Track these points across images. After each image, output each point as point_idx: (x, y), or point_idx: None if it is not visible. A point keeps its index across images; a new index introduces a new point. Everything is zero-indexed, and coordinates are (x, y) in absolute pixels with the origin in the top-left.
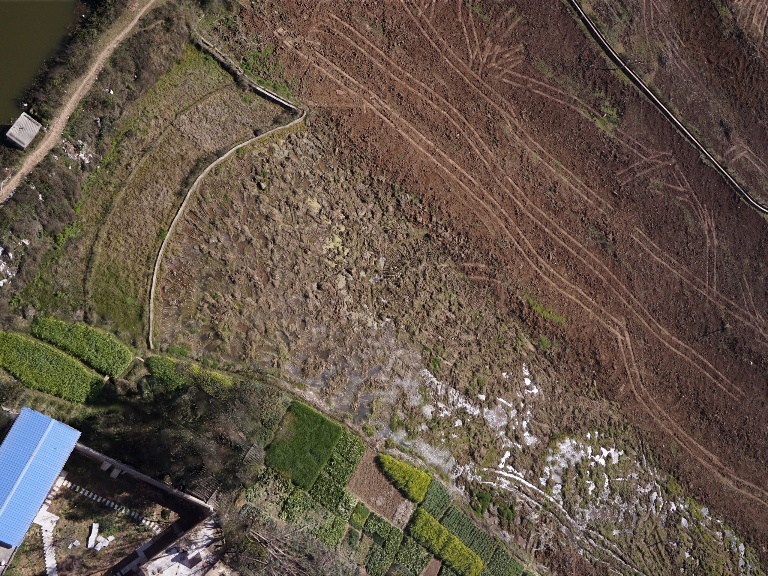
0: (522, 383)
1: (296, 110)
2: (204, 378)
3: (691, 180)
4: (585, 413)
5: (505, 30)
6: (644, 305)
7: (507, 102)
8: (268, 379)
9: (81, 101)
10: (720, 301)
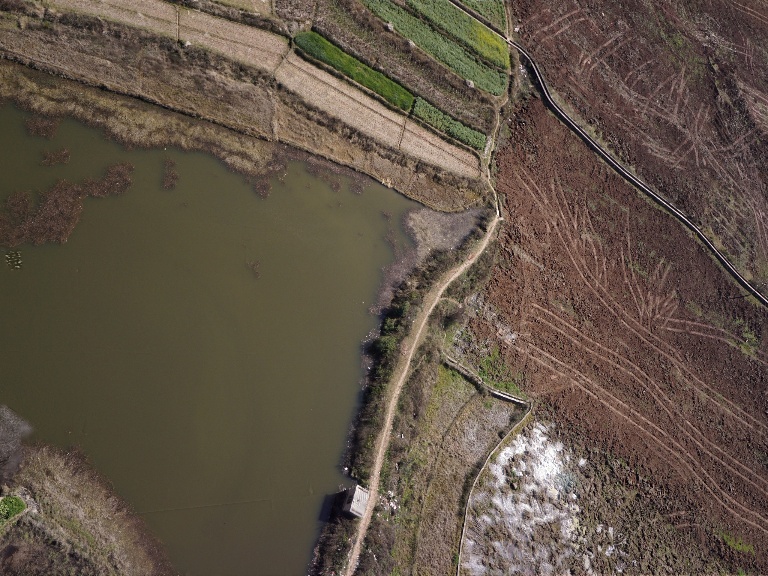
0: None
1: (526, 405)
2: None
3: None
4: None
5: (660, 281)
6: None
7: (673, 349)
8: None
9: (385, 454)
10: None
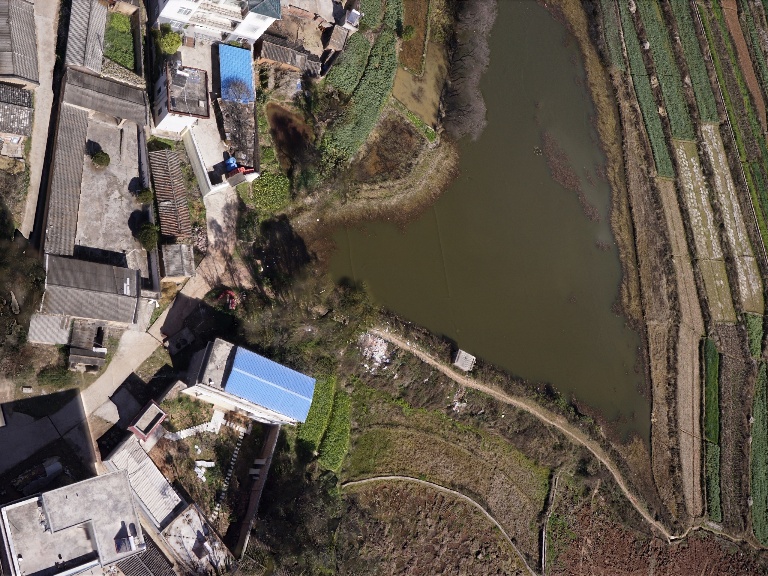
0: None
1: (542, 571)
2: None
3: None
4: None
5: None
6: None
7: None
8: None
9: (491, 396)
10: None
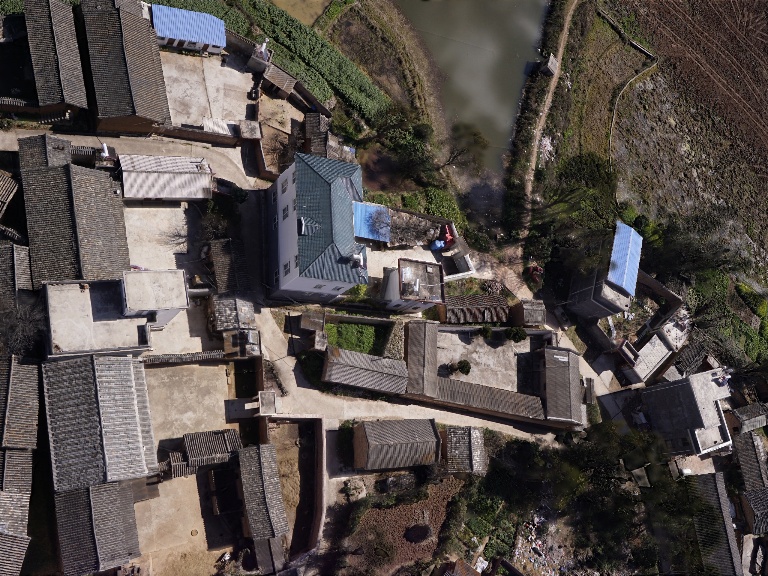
0: None
1: (654, 57)
2: (650, 226)
3: None
4: None
5: (753, 2)
6: None
7: (761, 54)
8: None
9: (565, 48)
10: None
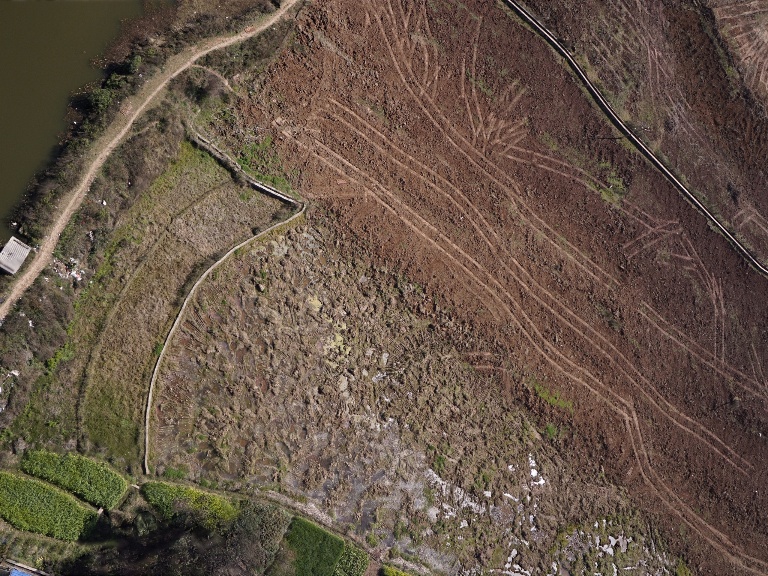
0: (528, 475)
1: (295, 204)
2: (202, 502)
3: (698, 248)
4: (593, 501)
5: (509, 104)
6: (652, 382)
7: (511, 179)
8: (268, 495)
9: (73, 216)
10: (728, 373)
